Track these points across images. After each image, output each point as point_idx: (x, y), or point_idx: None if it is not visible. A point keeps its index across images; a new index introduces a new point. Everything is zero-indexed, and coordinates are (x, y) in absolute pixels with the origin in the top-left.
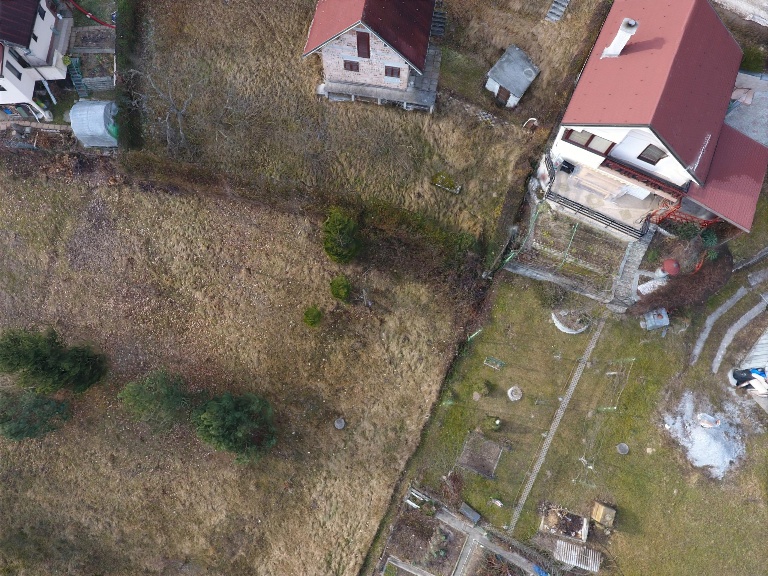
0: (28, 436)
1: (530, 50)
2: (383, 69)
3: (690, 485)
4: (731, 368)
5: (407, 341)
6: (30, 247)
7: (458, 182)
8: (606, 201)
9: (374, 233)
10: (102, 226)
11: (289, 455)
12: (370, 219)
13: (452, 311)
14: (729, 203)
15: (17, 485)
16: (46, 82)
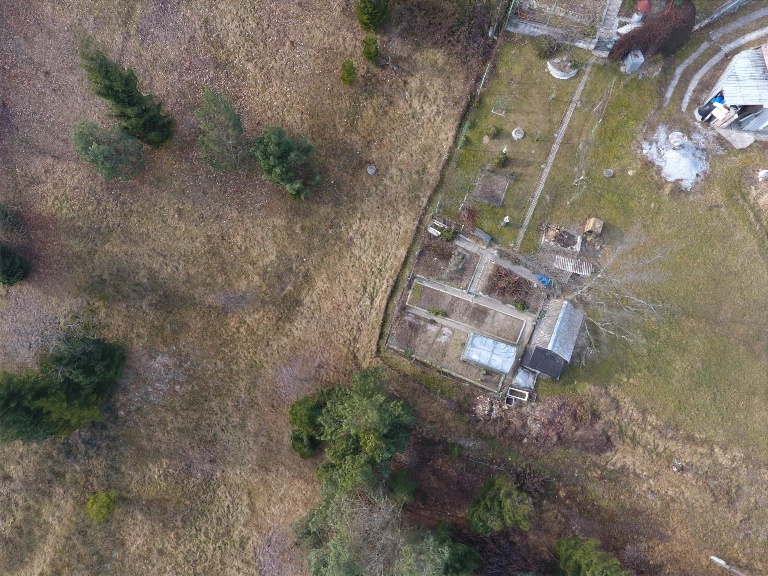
0: (113, 174)
1: None
2: None
3: (664, 198)
4: (697, 107)
5: (427, 98)
6: (107, 29)
7: None
8: None
9: (398, 3)
10: (168, 9)
11: (329, 201)
12: None
13: (464, 70)
14: None
15: (96, 240)
16: None
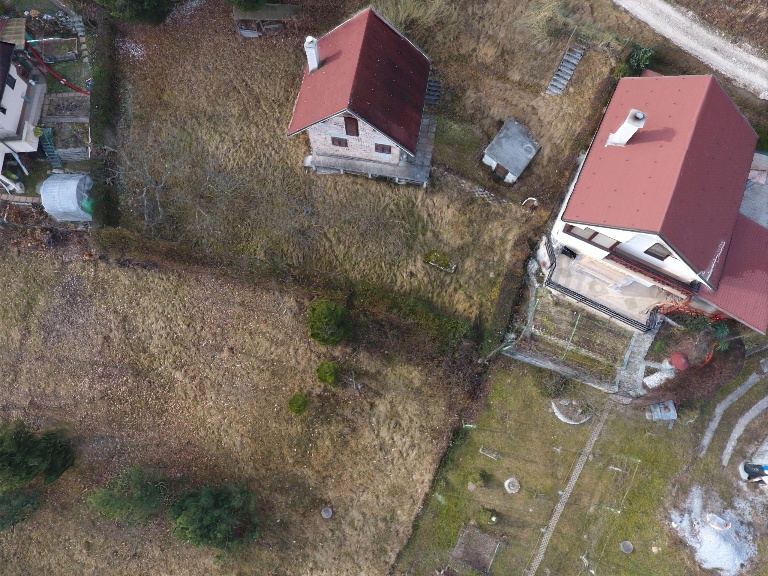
0: None
1: (530, 124)
2: (373, 146)
3: None
4: (742, 461)
5: (398, 426)
6: (1, 323)
7: (453, 260)
8: (610, 289)
9: (364, 314)
10: (77, 302)
11: (273, 544)
12: (359, 302)
13: (446, 396)
14: (743, 302)
15: None
16: (16, 154)
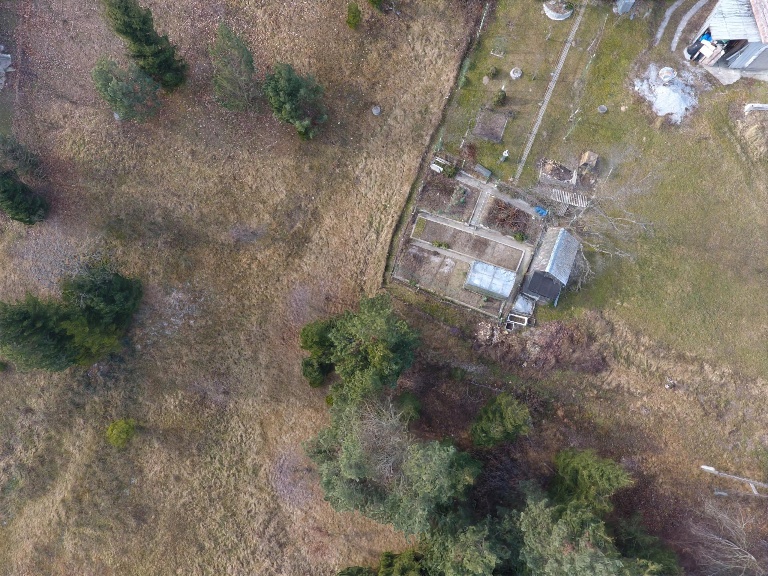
0: (130, 113)
1: None
2: None
3: (655, 131)
4: (686, 46)
5: (429, 41)
6: None
7: None
8: None
9: None
10: None
11: (336, 142)
12: None
13: (464, 13)
14: None
15: (113, 182)
16: None
